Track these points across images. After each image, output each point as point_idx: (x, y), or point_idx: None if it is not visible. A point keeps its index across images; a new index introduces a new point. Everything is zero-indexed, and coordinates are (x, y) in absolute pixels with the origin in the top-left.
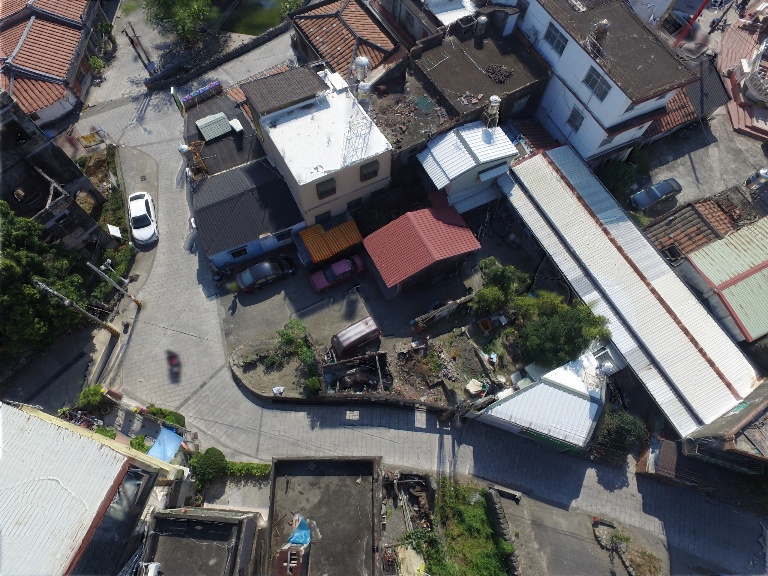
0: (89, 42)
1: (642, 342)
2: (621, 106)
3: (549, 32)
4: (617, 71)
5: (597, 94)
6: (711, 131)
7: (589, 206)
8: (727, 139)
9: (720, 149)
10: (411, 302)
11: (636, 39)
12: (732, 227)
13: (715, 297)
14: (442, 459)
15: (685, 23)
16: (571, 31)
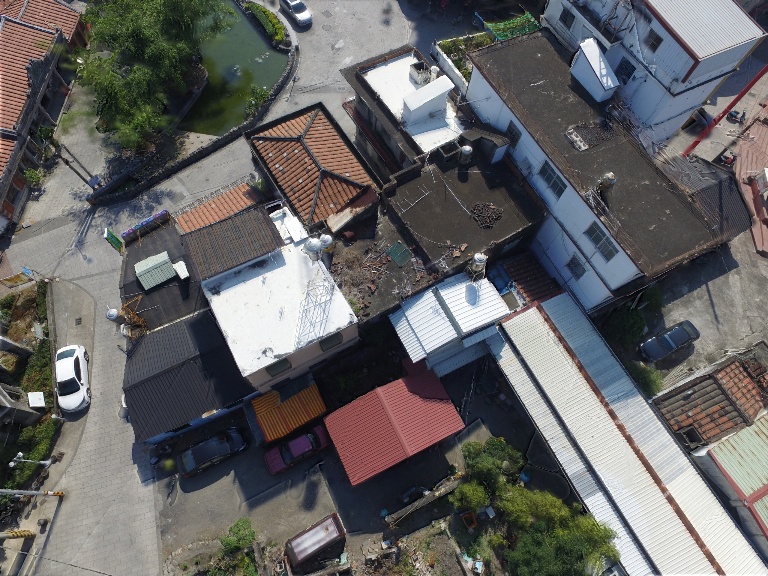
0: (25, 152)
1: (657, 568)
2: (630, 274)
3: (545, 169)
4: (626, 238)
5: (601, 251)
6: (731, 254)
7: (592, 379)
8: (750, 264)
9: (742, 277)
10: (383, 484)
11: (648, 187)
12: (762, 402)
13: (745, 510)
14: None
15: (699, 118)
16: (570, 178)
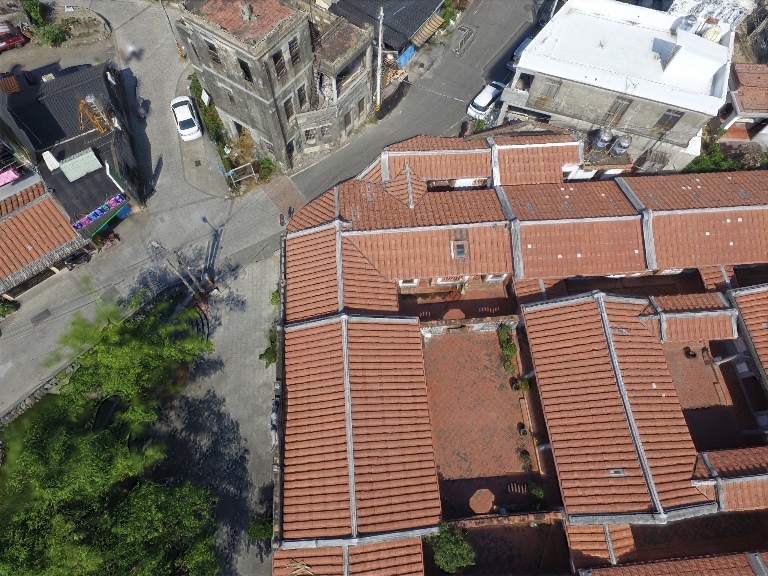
0: None
1: None
2: None
3: None
4: None
5: None
6: None
7: None
8: None
9: None
10: None
11: None
12: None
13: None
14: None
15: None
16: None
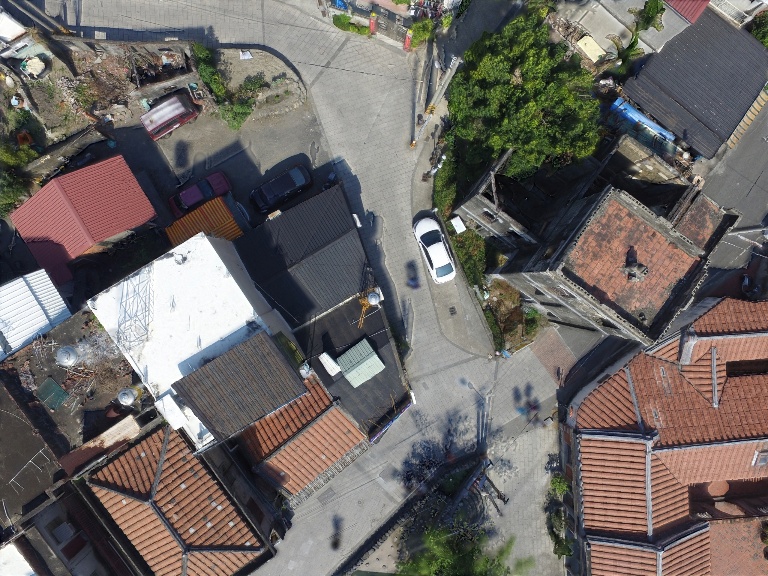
0: None
1: None
2: None
3: None
4: None
5: None
6: None
7: None
8: None
9: None
10: None
11: None
12: None
13: None
14: (77, 1)
15: None
16: None
